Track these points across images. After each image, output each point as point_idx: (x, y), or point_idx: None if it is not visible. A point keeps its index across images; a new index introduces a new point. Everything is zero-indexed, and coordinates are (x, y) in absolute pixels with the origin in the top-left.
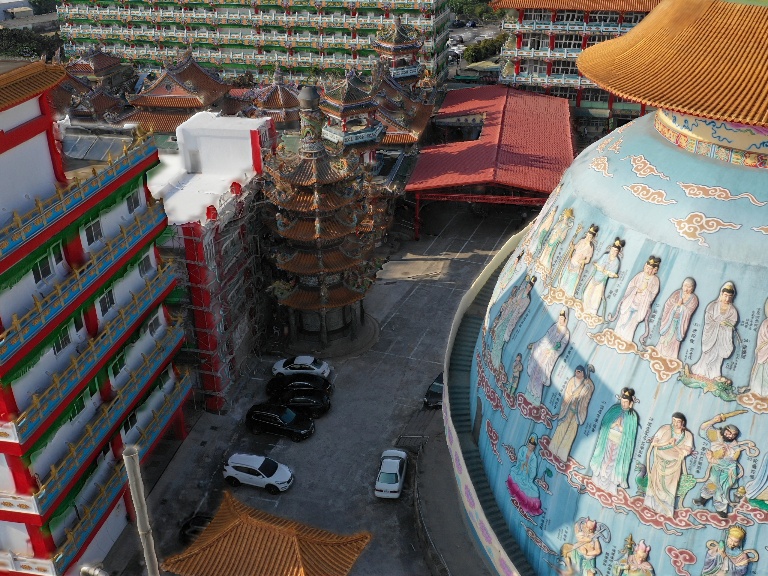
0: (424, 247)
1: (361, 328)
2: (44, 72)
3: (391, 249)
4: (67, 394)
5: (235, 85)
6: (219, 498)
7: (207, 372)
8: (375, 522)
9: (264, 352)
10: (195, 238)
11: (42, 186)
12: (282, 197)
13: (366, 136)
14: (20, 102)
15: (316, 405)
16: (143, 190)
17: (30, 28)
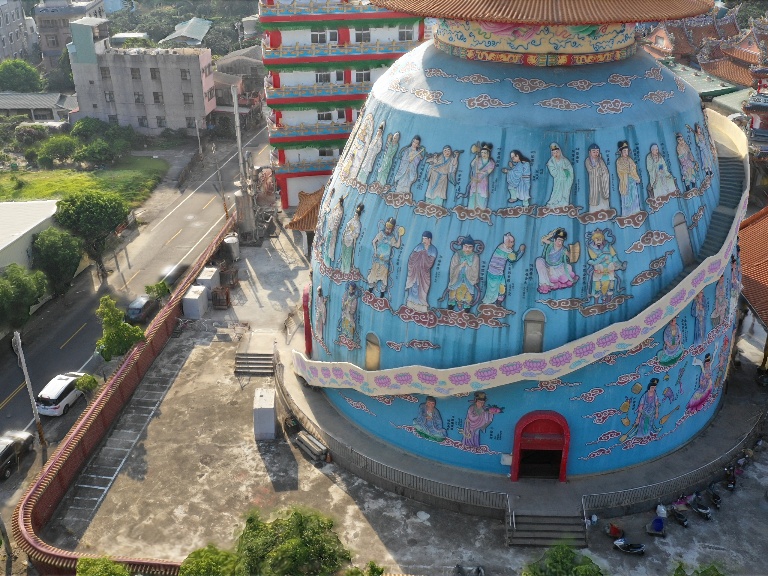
0: None
1: None
2: None
3: None
4: (304, 96)
5: None
6: None
7: None
8: None
9: None
10: None
11: None
12: None
13: None
14: None
15: None
16: (418, 33)
17: None
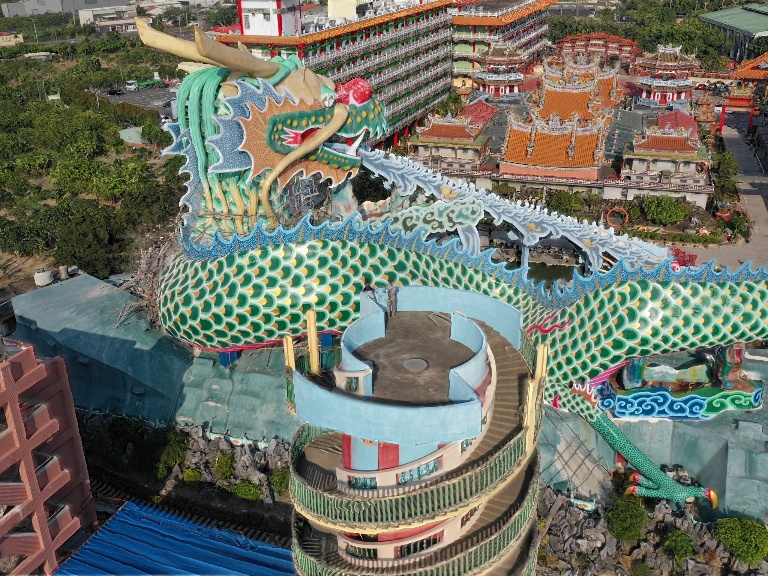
0: None
1: None
2: None
3: None
4: None
5: None
6: None
7: None
8: None
9: None
10: None
11: None
12: None
13: None
14: None
15: None
16: None
17: None
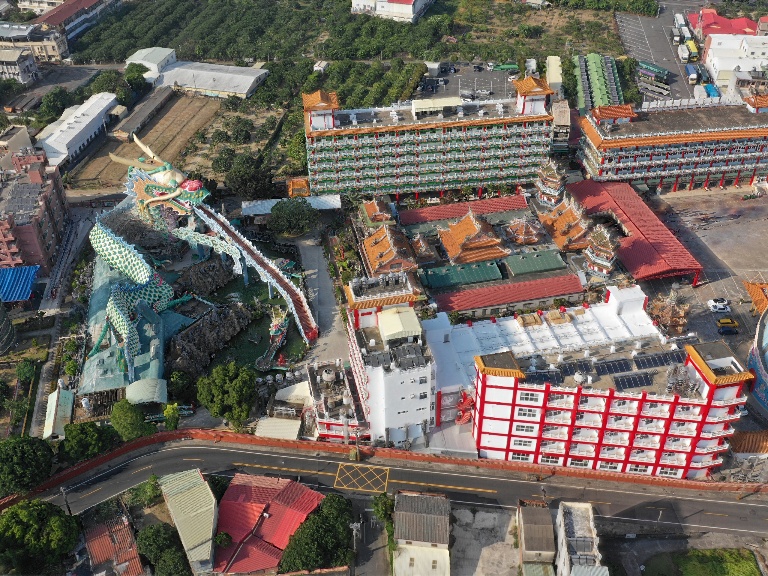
0: None
1: None
2: None
3: None
4: None
5: (445, 201)
6: None
7: None
8: (748, 423)
9: None
10: None
11: None
12: None
13: None
14: None
15: None
16: None
17: (140, 127)
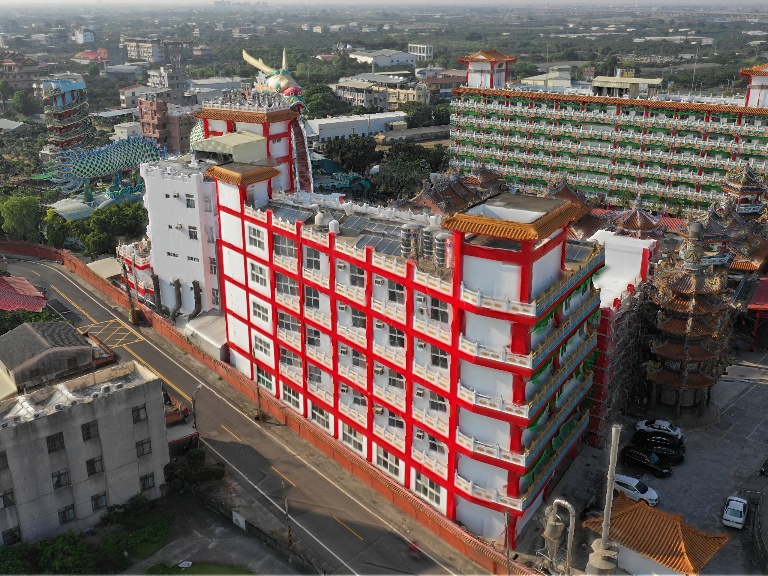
0: (758, 358)
1: (706, 409)
2: (571, 207)
3: (729, 355)
4: (547, 398)
5: None
6: (604, 501)
7: (595, 415)
8: None
9: (628, 413)
10: (610, 318)
11: (558, 272)
12: (665, 299)
13: (718, 261)
14: (565, 224)
15: (674, 455)
16: (590, 282)
17: (404, 139)
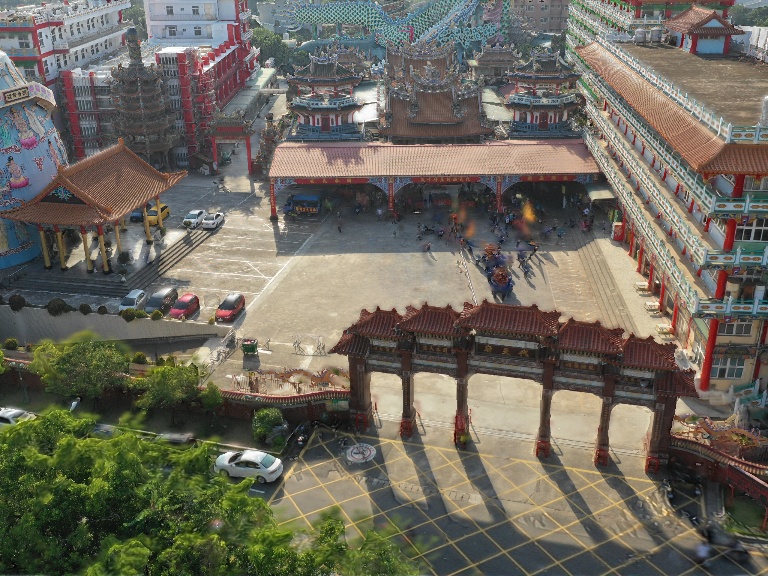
0: None
1: None
2: None
3: None
4: None
5: None
6: None
7: None
8: None
9: None
10: None
11: None
12: None
13: None
14: None
15: None
16: (33, 43)
17: None
